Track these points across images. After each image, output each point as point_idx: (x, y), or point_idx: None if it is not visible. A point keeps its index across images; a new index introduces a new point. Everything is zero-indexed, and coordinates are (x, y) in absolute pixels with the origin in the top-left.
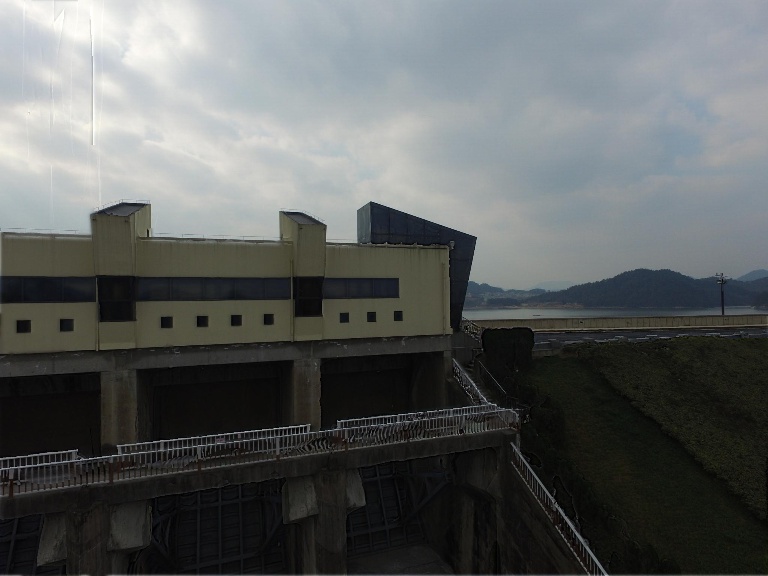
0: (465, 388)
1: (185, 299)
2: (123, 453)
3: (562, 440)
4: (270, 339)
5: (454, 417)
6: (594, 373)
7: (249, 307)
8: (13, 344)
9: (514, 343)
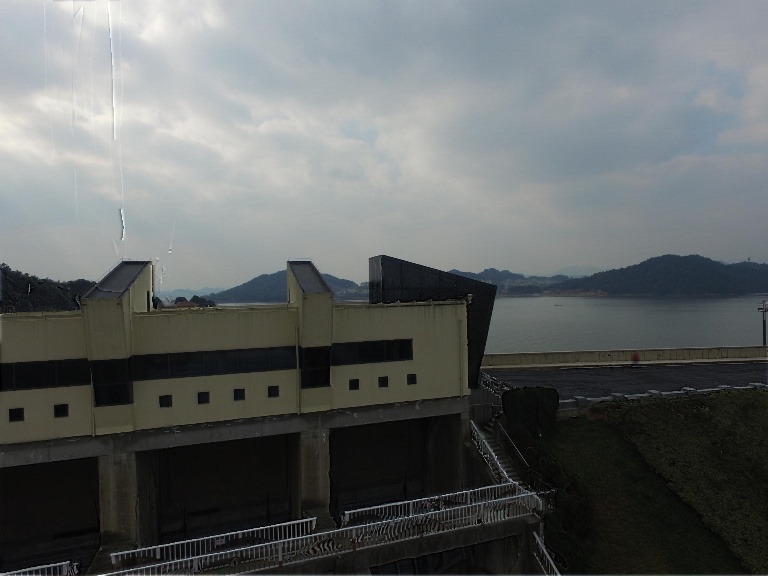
0: (484, 456)
1: (184, 375)
2: (117, 562)
3: (590, 530)
4: (275, 412)
5: (471, 506)
6: (625, 442)
7: (252, 380)
8: (6, 434)
9: (537, 405)
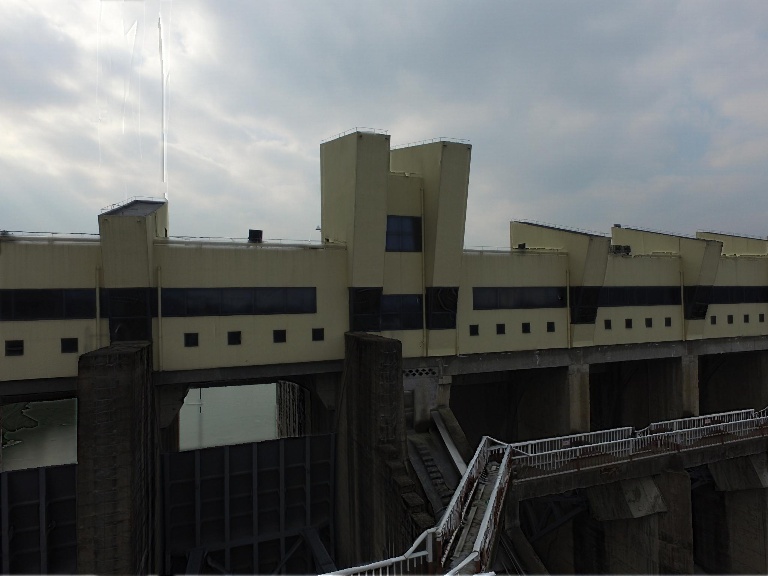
0: None
1: None
2: None
3: None
4: None
5: None
6: None
7: None
8: (742, 330)
9: None
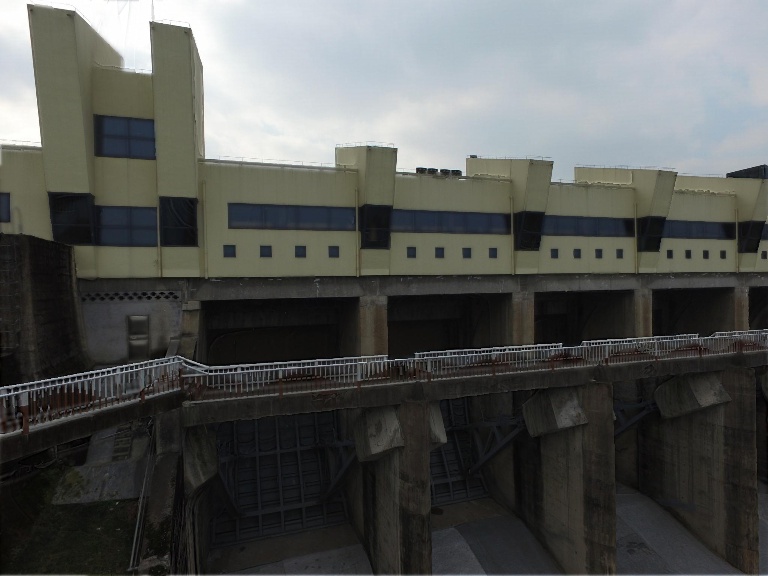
0: None
1: (678, 237)
2: None
3: None
4: (724, 270)
5: None
6: None
7: (712, 245)
8: (593, 266)
9: None
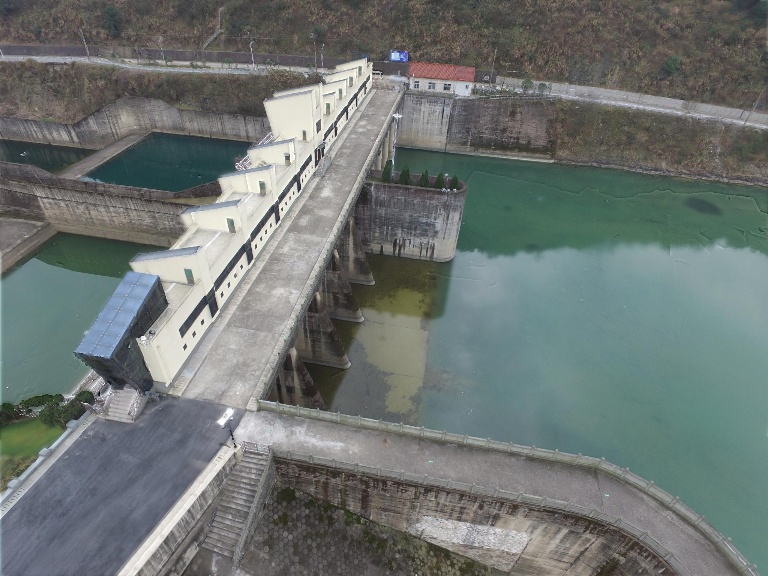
0: None
1: None
2: None
3: None
4: None
5: None
6: None
7: None
8: None
9: None
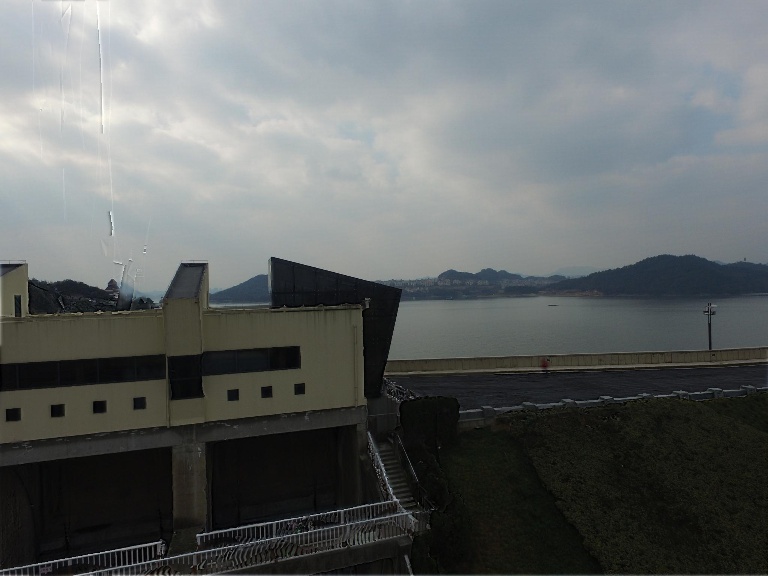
0: (376, 470)
1: (36, 387)
2: None
3: (465, 553)
4: (142, 425)
5: (336, 528)
6: (524, 455)
7: (115, 391)
8: None
9: (435, 416)
